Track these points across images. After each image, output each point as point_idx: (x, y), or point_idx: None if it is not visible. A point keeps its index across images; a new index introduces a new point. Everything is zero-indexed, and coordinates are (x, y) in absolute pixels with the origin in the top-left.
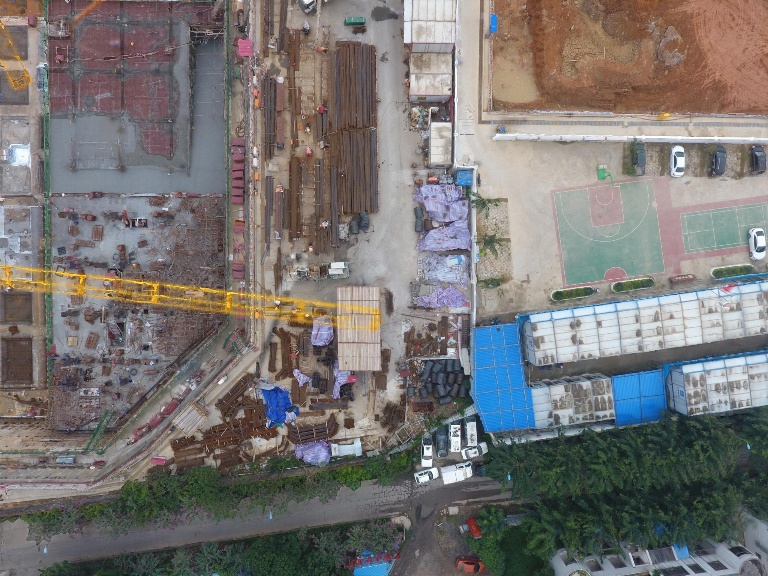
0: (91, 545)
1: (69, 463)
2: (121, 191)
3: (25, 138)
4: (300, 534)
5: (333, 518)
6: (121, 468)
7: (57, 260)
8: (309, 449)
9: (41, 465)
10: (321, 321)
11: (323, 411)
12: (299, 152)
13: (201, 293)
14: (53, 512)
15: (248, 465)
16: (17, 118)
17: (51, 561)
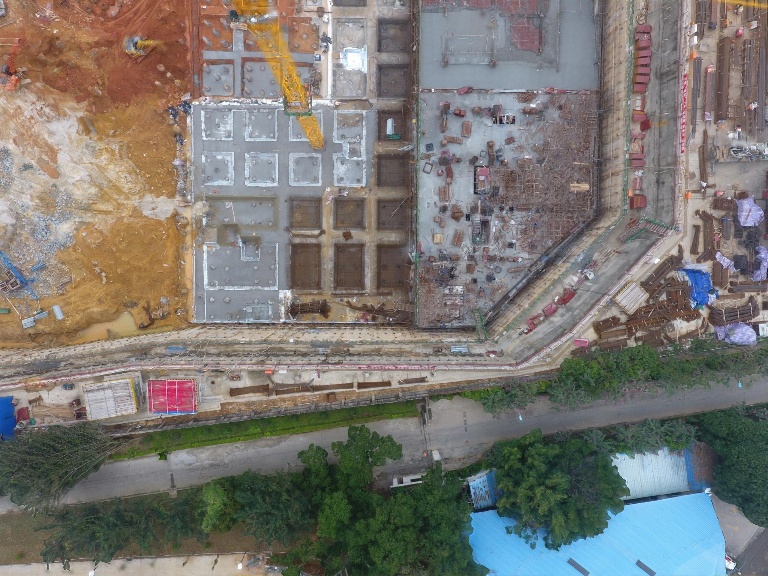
0: (517, 425)
1: (466, 352)
2: (490, 87)
3: (359, 41)
4: (741, 409)
5: (752, 399)
6: (545, 350)
7: (425, 157)
8: (736, 329)
9: (441, 353)
10: (750, 202)
11: (743, 294)
12: (727, 33)
13: (586, 185)
14: (497, 388)
15: (671, 346)
16: (353, 21)
17: (477, 441)
